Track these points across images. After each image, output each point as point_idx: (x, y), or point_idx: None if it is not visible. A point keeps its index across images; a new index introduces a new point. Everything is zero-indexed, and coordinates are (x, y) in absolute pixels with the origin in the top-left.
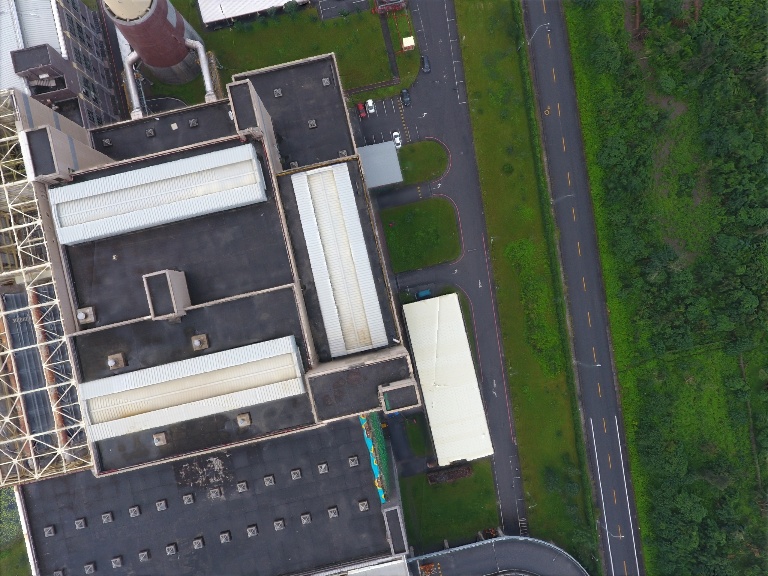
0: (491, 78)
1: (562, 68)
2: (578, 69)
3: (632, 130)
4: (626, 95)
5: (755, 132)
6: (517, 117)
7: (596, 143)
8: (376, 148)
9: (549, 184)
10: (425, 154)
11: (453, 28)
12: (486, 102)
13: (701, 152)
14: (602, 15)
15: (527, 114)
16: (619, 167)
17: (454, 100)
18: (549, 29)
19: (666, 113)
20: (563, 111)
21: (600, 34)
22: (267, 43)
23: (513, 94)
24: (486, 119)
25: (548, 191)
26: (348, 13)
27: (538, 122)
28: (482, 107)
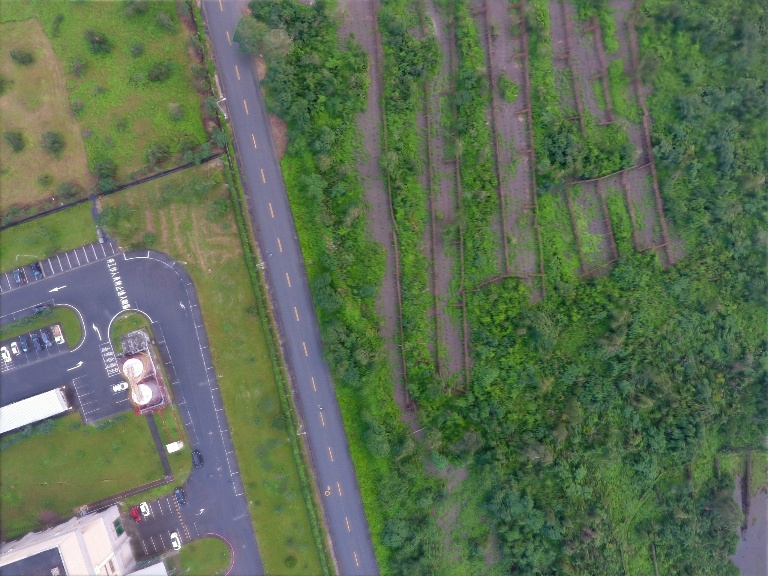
0: (264, 469)
1: (338, 446)
2: (353, 449)
3: (413, 507)
4: (402, 474)
5: (537, 493)
6: (296, 504)
7: (379, 522)
8: (145, 573)
9: (336, 567)
10: (206, 552)
11: (222, 418)
12: (263, 493)
13: (488, 514)
14: (368, 398)
15: (305, 502)
16: (400, 553)
17: (230, 493)
18: (321, 407)
19: (442, 492)
20: (343, 490)
21: (367, 420)
22: (31, 455)
23: (289, 481)
24: (264, 510)
25: (336, 575)
26: (106, 426)
27: (319, 506)
28: (259, 498)
